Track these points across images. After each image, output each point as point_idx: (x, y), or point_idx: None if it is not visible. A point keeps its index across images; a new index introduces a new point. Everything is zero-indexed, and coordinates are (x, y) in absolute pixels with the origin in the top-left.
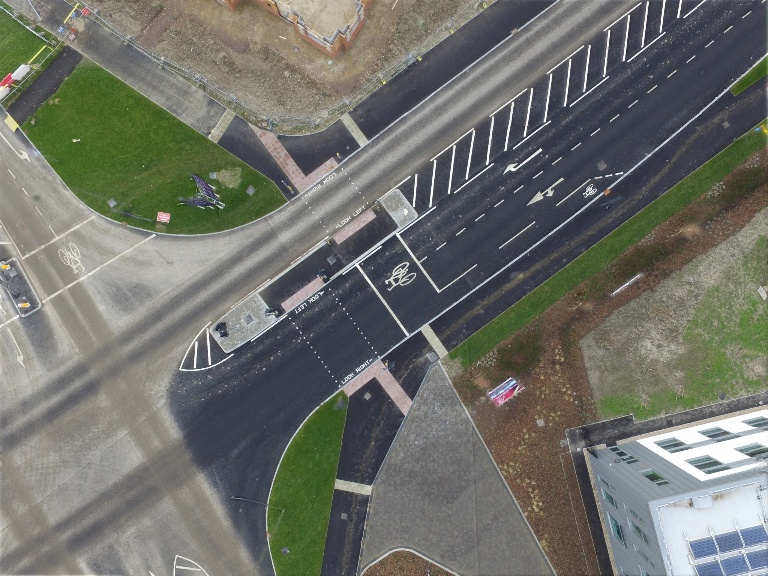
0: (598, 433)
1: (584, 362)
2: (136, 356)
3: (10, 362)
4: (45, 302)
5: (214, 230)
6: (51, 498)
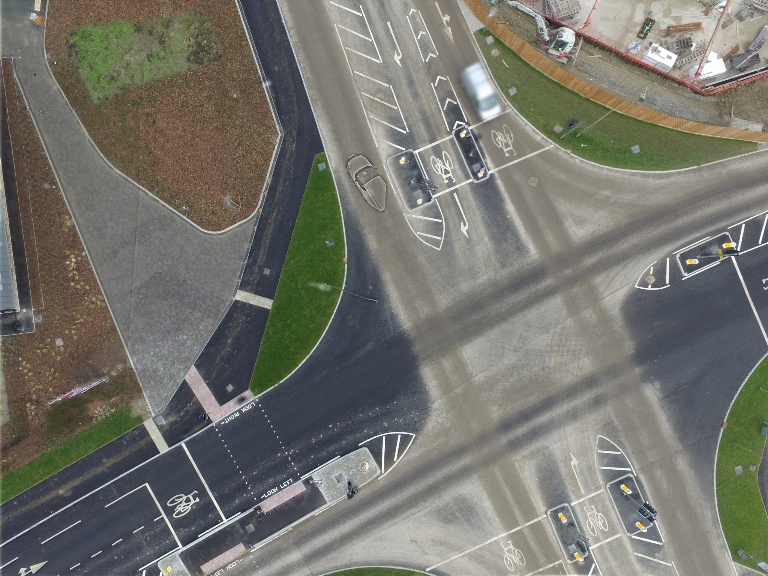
0: (3, 326)
1: (8, 399)
2: (458, 453)
3: (585, 460)
4: (544, 515)
5: (365, 570)
6: (557, 321)
